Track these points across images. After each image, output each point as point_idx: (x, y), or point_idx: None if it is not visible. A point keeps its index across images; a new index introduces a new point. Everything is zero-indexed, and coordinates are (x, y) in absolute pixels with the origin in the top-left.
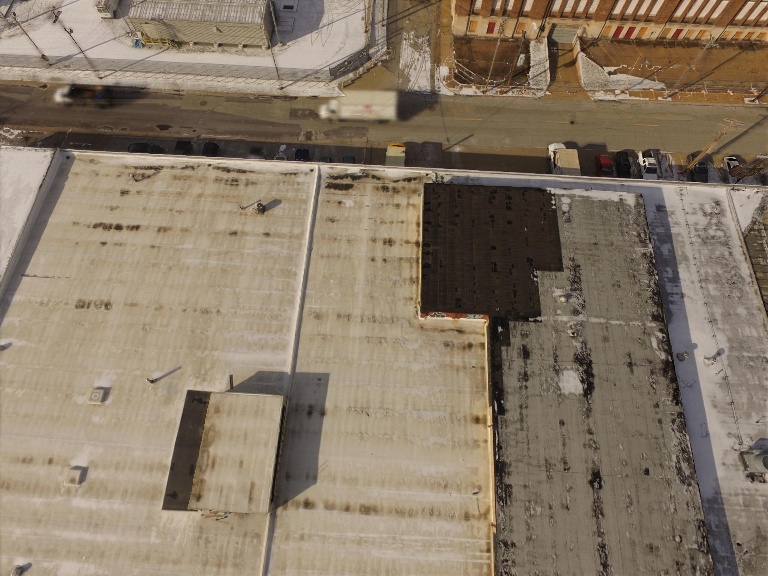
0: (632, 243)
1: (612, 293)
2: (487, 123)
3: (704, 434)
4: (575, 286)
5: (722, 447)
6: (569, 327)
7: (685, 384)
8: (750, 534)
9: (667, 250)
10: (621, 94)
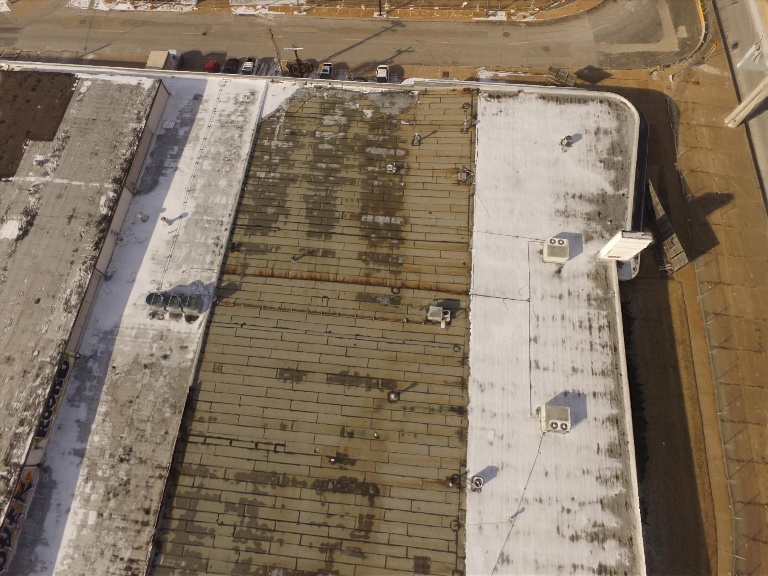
0: (128, 119)
1: (87, 160)
2: (127, 34)
3: (130, 280)
4: (56, 153)
5: (141, 291)
6: (32, 186)
7: (136, 240)
8: (128, 360)
9: (183, 132)
10: (261, 9)
